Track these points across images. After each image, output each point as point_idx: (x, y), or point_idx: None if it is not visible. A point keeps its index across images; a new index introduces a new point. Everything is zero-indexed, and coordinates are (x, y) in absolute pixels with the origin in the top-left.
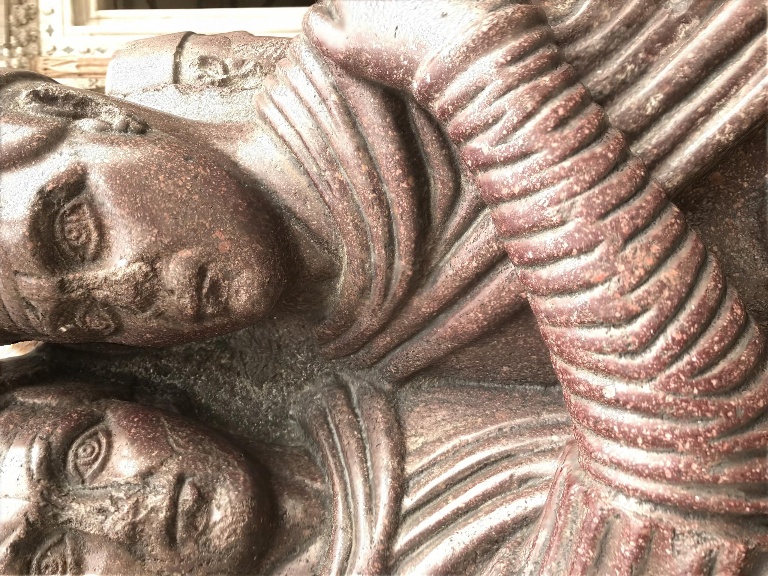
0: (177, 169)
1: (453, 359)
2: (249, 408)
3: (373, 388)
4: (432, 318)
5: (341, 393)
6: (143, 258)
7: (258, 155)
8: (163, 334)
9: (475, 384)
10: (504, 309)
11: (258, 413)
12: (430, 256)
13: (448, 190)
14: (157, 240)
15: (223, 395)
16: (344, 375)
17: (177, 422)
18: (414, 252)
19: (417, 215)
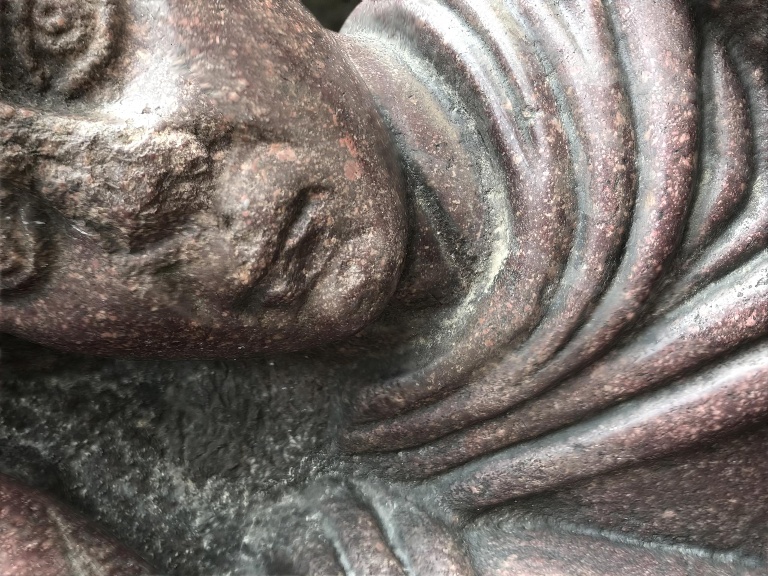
0: (292, 6)
1: (589, 485)
2: (170, 520)
3: (426, 516)
4: (605, 406)
5: (366, 516)
6: (198, 127)
7: (380, 71)
8: (141, 318)
9: (593, 534)
10: (767, 408)
11: (185, 533)
12: (657, 297)
13: (736, 193)
14: (242, 101)
15: (125, 488)
16: (364, 486)
17: (81, 524)
18: (654, 280)
19: (683, 218)
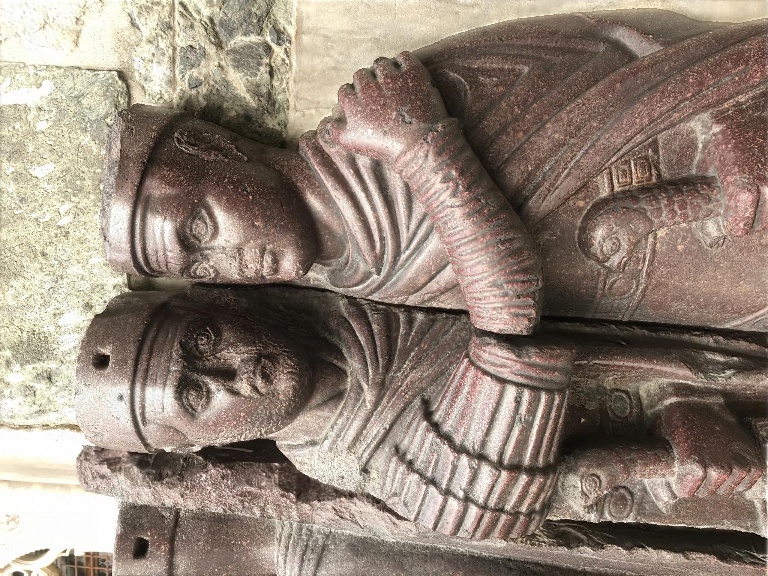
0: None
1: None
2: None
3: None
4: None
5: None
6: None
7: None
8: None
9: None
10: None
11: None
12: None
13: None
14: None
15: None
16: None
17: None
18: None
19: None
